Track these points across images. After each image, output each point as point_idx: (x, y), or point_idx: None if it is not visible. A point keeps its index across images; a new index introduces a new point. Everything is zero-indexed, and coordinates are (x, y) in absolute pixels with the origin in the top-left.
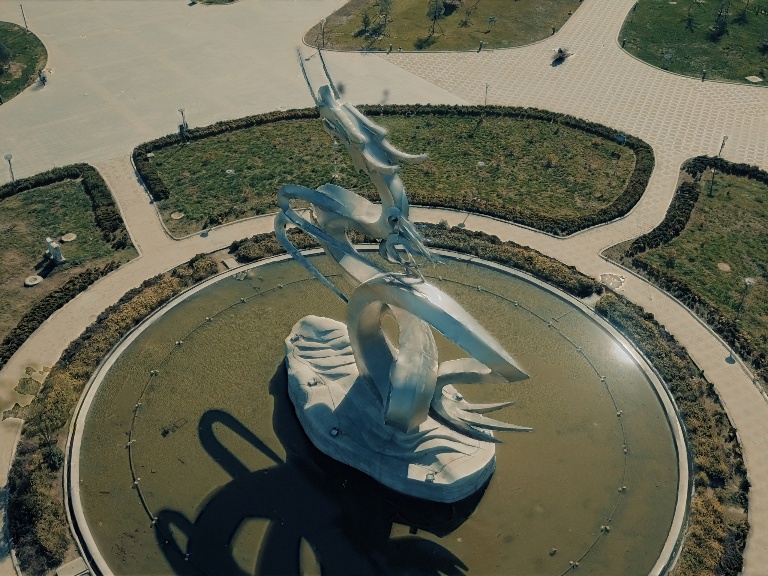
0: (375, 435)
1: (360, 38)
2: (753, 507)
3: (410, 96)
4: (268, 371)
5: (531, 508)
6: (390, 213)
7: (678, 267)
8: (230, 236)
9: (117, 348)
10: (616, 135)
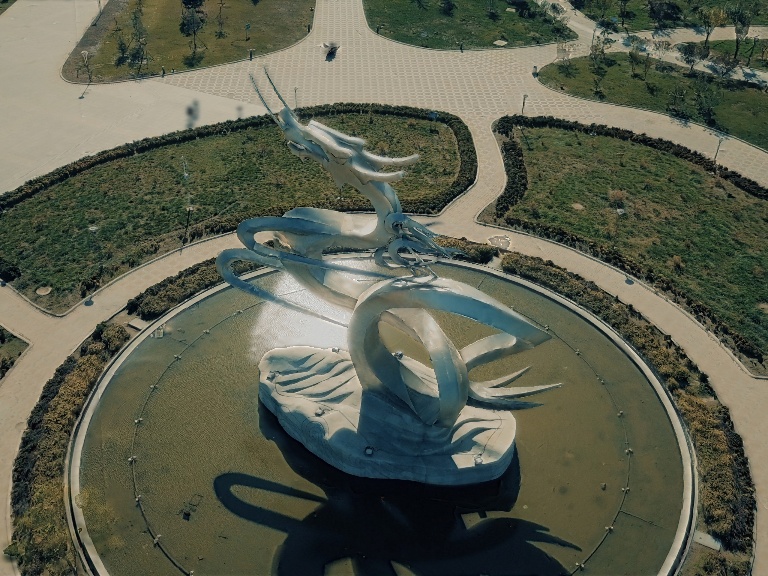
0: (406, 441)
1: (124, 66)
2: (719, 393)
3: (214, 114)
4: (251, 418)
5: (563, 457)
6: (393, 219)
7: (544, 216)
8: (119, 297)
9: (73, 448)
10: (425, 113)
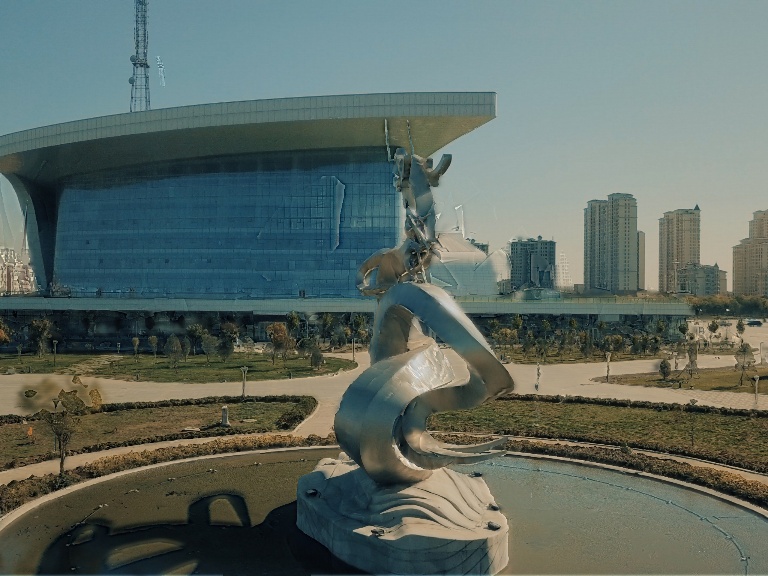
0: (354, 503)
1: (653, 382)
2: None
3: None
4: None
5: None
6: None
7: None
8: None
9: (201, 456)
10: None
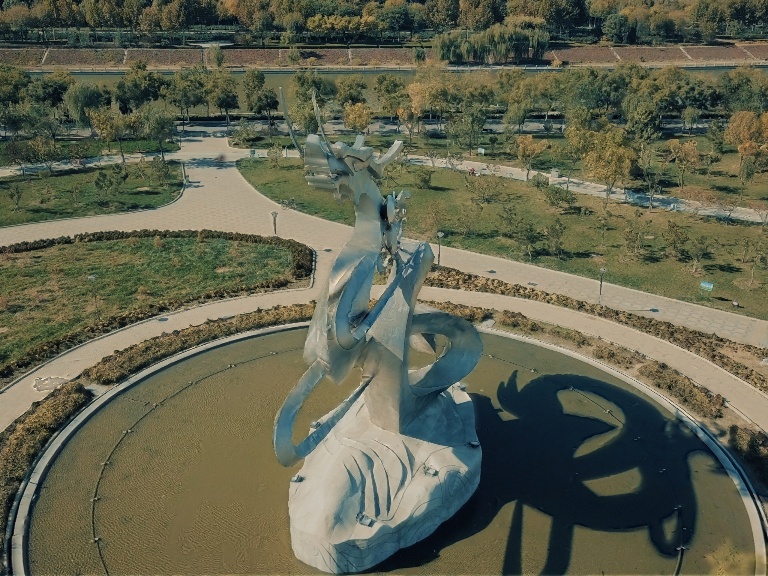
0: None
1: None
2: None
3: None
4: None
5: None
6: None
7: (8, 351)
8: None
9: None
10: None
